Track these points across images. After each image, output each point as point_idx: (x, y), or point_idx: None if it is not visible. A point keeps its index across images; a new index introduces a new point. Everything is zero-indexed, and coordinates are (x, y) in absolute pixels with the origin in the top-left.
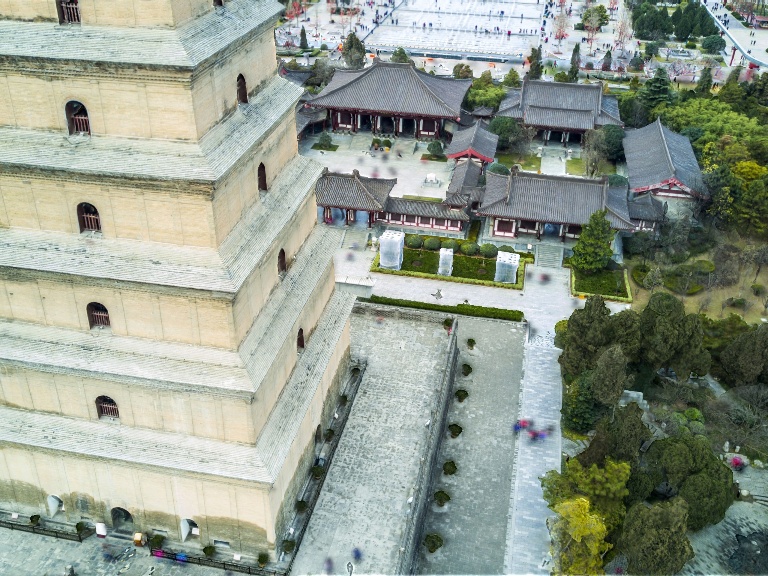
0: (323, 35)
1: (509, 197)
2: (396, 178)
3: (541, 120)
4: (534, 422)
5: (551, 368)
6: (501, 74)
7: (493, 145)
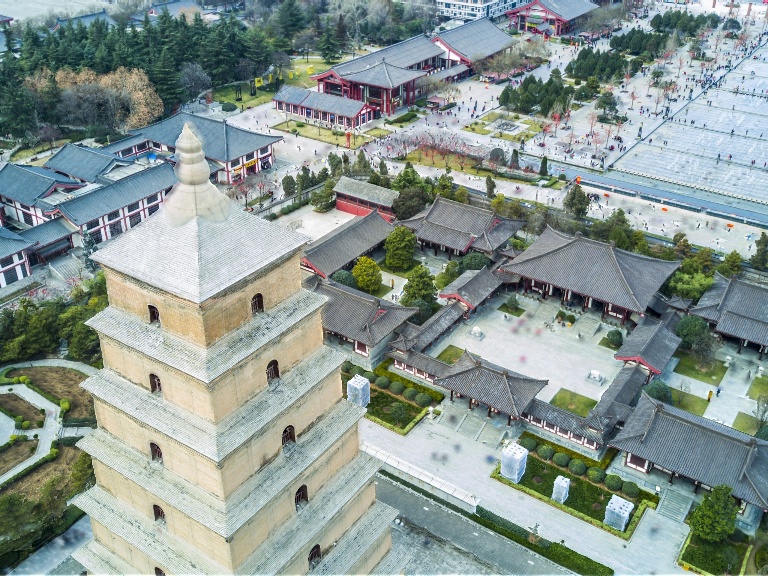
0: (575, 151)
1: (646, 435)
2: (548, 380)
3: (735, 329)
4: None
5: None
6: (723, 252)
7: (669, 352)
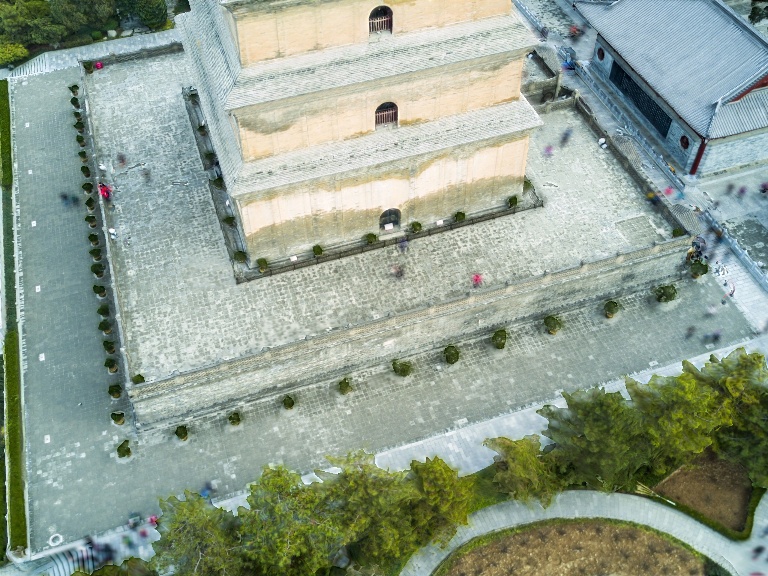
0: None
1: None
2: None
3: None
4: (165, 42)
5: (81, 51)
6: None
7: None
